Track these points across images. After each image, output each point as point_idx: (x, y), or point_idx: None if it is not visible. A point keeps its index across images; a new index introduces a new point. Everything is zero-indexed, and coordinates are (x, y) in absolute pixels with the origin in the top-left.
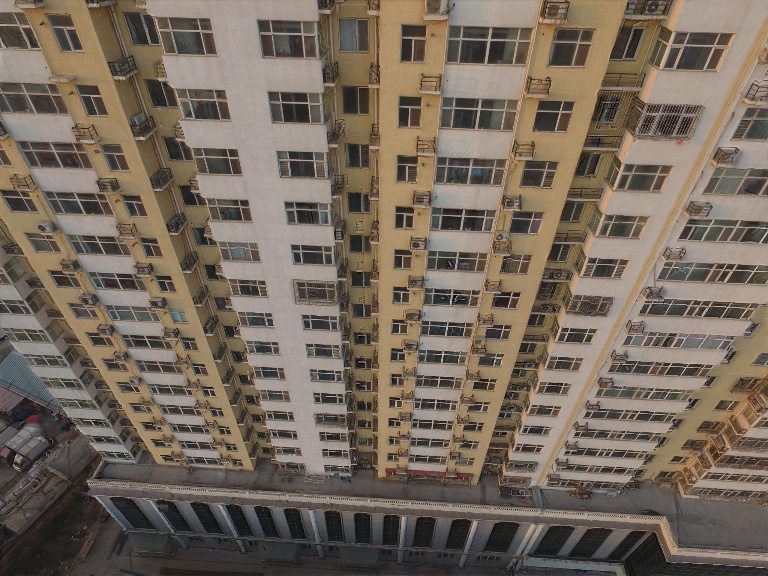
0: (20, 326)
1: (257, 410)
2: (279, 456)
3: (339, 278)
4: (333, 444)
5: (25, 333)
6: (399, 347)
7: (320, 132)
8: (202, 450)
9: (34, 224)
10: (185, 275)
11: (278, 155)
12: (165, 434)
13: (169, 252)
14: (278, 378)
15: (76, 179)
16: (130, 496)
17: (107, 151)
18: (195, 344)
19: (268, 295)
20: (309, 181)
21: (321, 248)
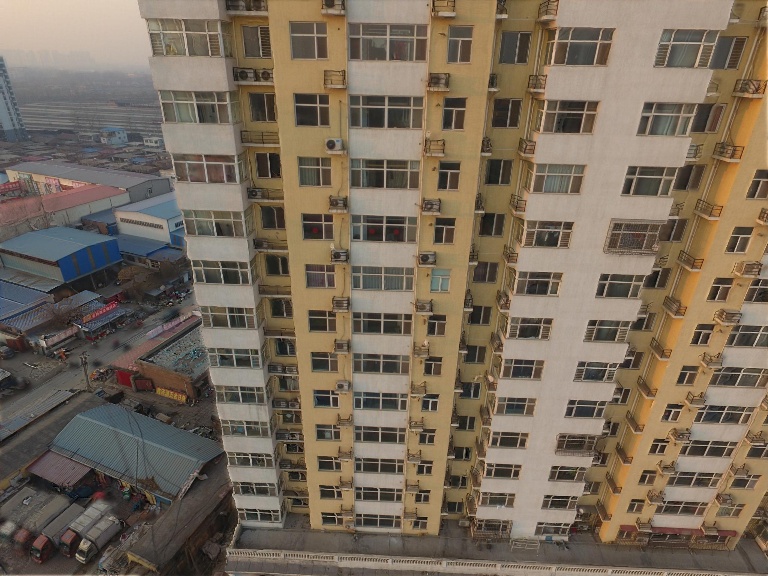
0: (226, 303)
1: (465, 440)
2: (483, 509)
3: (670, 216)
4: (563, 486)
5: (226, 315)
6: (709, 322)
7: (728, 0)
8: (382, 502)
9: (316, 143)
10: (474, 217)
11: (662, 36)
12: (343, 476)
13: (470, 181)
14: (530, 378)
15: (398, 76)
16: (283, 572)
17: (452, 36)
18: (443, 325)
19: (569, 245)
20: (688, 71)
21: (662, 171)
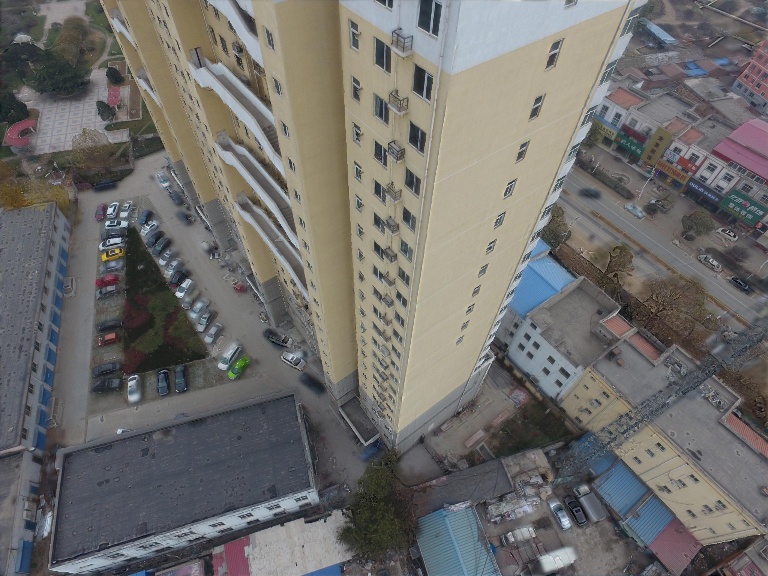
0: None
1: None
2: None
3: None
4: None
5: None
6: None
7: None
8: None
9: None
10: None
11: None
12: None
13: None
14: None
15: None
16: None
17: None
18: None
19: None
20: None
21: None
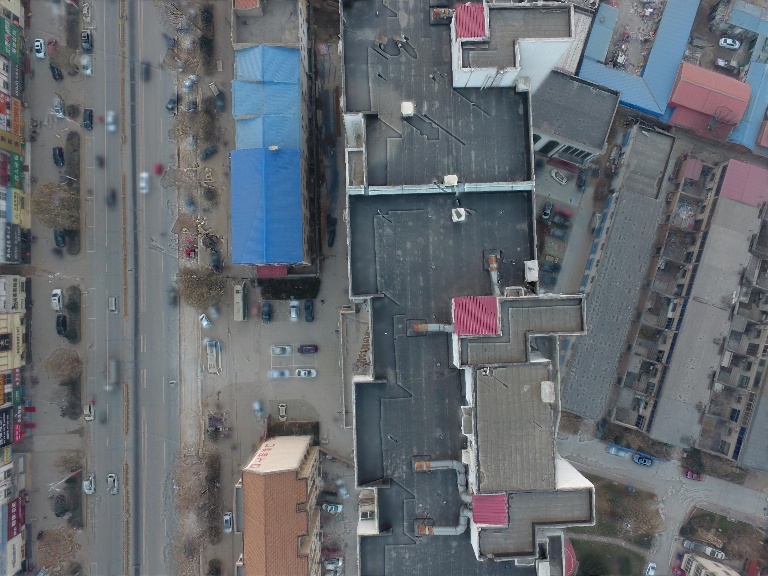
0: None
1: None
2: None
3: None
4: None
5: None
6: None
7: None
8: None
9: None
10: None
11: None
12: None
13: None
14: None
15: None
16: None
17: None
18: None
19: None
20: None
21: None
